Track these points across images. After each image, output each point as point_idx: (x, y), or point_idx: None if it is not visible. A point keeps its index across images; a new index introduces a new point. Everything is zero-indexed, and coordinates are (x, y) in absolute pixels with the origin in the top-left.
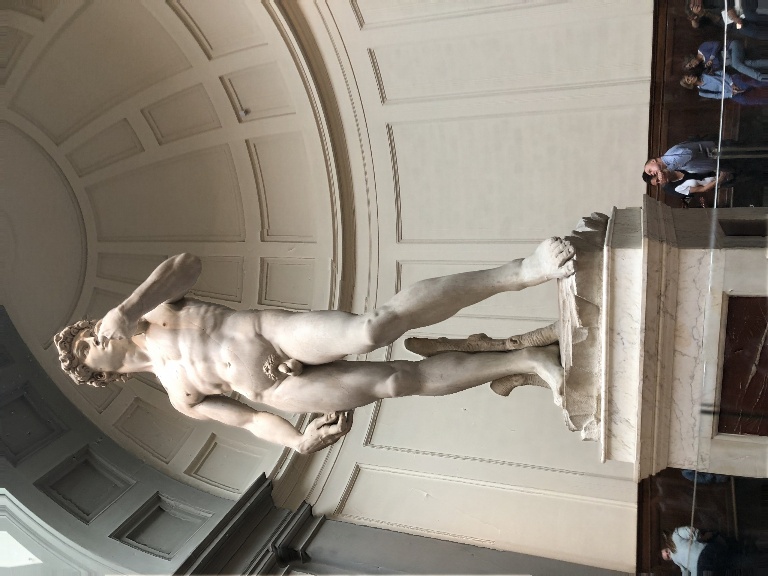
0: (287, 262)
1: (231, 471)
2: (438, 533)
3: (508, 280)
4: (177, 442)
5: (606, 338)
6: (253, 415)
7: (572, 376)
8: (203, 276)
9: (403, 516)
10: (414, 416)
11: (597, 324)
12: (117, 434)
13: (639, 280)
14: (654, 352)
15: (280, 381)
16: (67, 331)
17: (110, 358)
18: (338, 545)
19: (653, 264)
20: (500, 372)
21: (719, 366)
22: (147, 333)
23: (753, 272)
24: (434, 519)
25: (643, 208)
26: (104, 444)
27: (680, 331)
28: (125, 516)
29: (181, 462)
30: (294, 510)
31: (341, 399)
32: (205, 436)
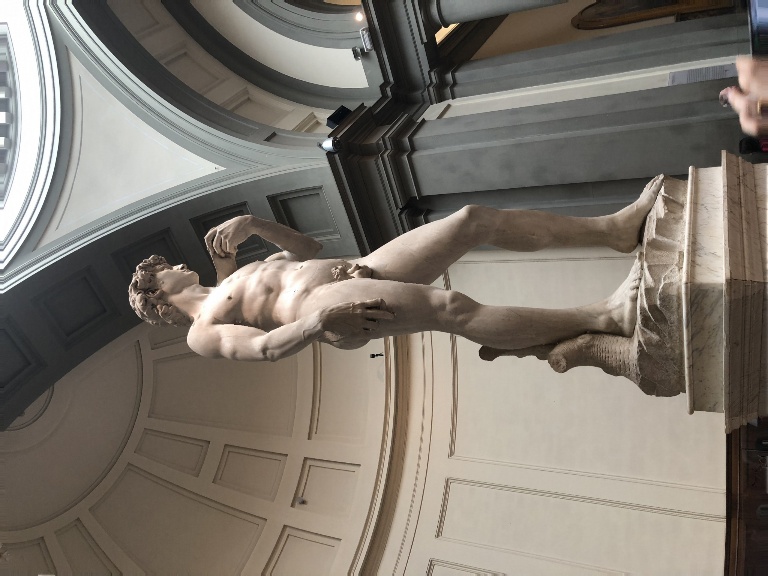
0: None
1: None
2: None
3: None
4: None
5: (690, 205)
6: None
7: (654, 243)
8: None
9: None
10: None
11: (681, 213)
12: None
13: None
14: None
15: None
16: None
17: (181, 277)
18: None
19: (731, 162)
20: (569, 311)
21: None
22: None
23: None
24: None
25: None
26: None
27: (761, 198)
28: None
29: None
30: None
31: (395, 287)
32: None
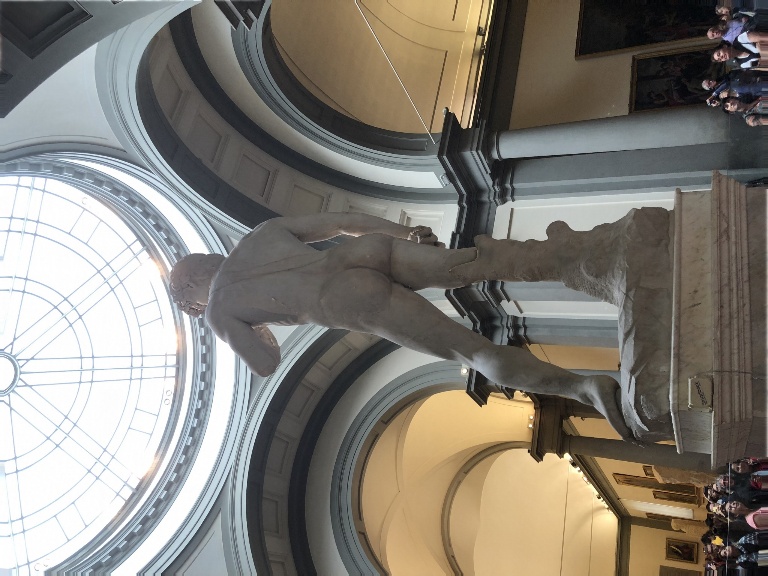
0: None
1: None
2: None
3: None
4: None
5: None
6: None
7: None
8: None
9: None
10: None
11: None
12: None
13: None
14: None
15: None
16: None
17: None
18: None
19: None
20: None
21: None
22: None
23: None
24: None
25: None
26: None
27: None
28: None
29: None
30: None
31: None
32: None
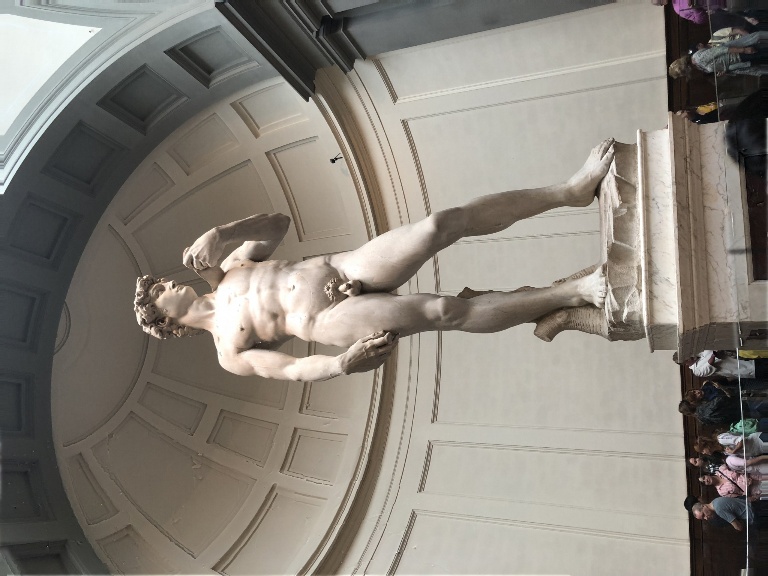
0: (319, 436)
1: None
2: None
3: (558, 187)
4: None
5: (643, 203)
6: (297, 359)
7: (614, 251)
8: (233, 436)
9: None
10: None
11: (635, 201)
12: (97, 550)
13: (668, 153)
14: (685, 205)
15: (337, 303)
16: None
17: (180, 300)
18: None
19: (678, 132)
20: (545, 297)
21: (745, 215)
22: (221, 282)
23: (760, 134)
24: None
25: None
26: (82, 547)
27: (706, 189)
28: None
29: None
30: None
31: (392, 312)
32: None
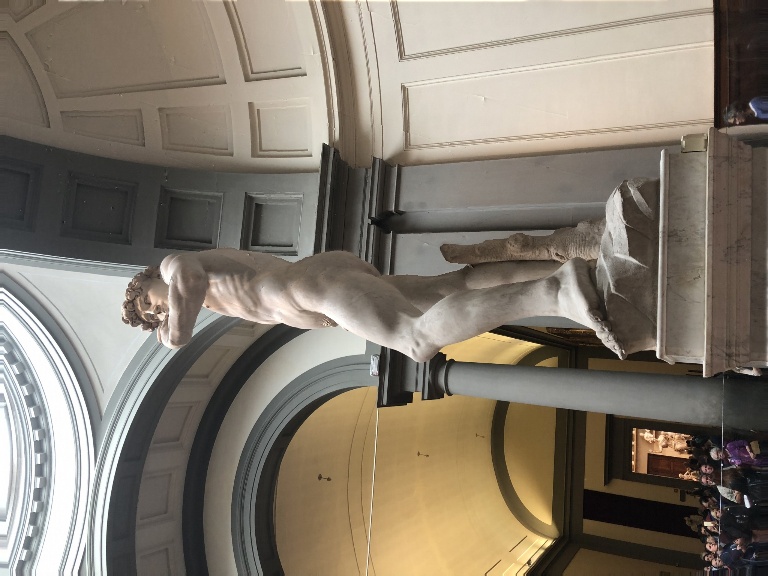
0: None
1: (290, 135)
2: (508, 140)
3: None
4: (225, 128)
5: None
6: None
7: None
8: None
9: (469, 131)
10: (439, 5)
11: None
12: (173, 154)
13: None
14: None
15: None
16: (127, 314)
17: None
18: (424, 196)
19: None
20: None
21: None
22: None
23: None
24: (500, 125)
25: (708, 222)
26: (172, 176)
27: None
28: (238, 231)
29: (243, 148)
30: (368, 163)
31: None
32: (244, 108)
